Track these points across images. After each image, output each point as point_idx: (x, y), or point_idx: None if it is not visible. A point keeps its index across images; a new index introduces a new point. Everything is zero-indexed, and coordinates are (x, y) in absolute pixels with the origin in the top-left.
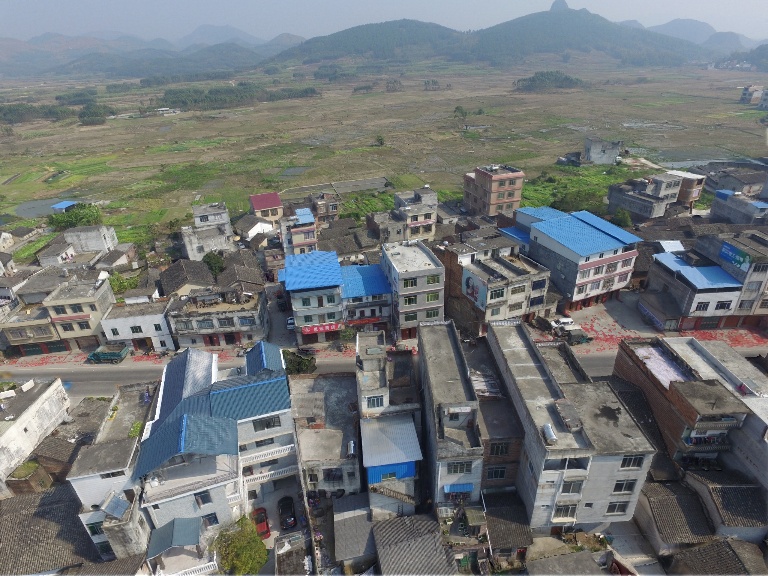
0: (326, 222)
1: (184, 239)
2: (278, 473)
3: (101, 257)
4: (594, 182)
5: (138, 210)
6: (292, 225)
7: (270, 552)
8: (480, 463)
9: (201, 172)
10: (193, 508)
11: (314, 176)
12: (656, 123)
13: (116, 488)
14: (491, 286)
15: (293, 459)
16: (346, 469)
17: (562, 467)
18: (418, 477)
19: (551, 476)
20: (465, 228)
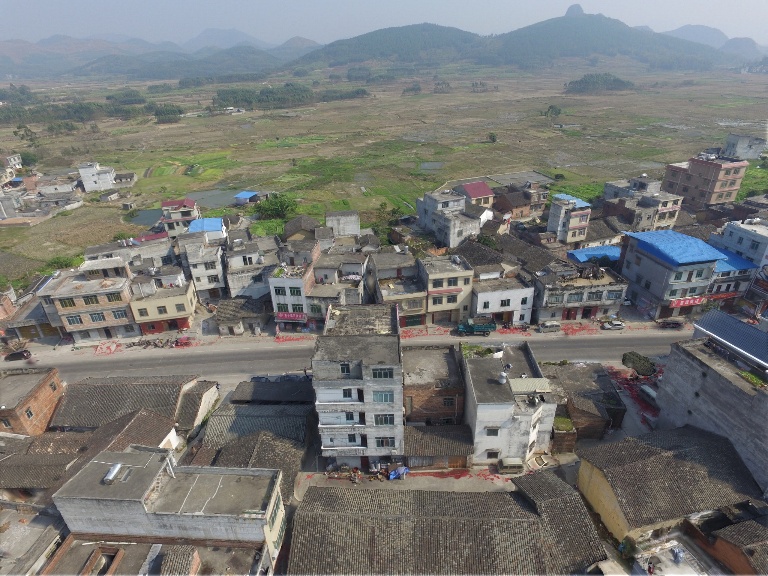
0: (534, 211)
1: (450, 223)
2: None
3: (360, 241)
4: (758, 175)
5: (316, 200)
6: (570, 208)
7: None
8: None
9: (336, 166)
10: None
11: (459, 170)
12: (751, 122)
13: None
14: None
15: None
16: None
17: None
18: None
19: None
20: (728, 213)
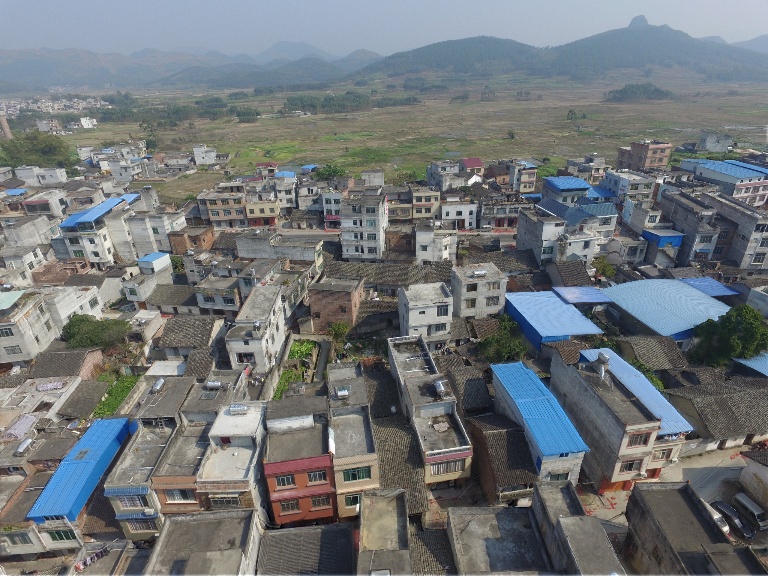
0: None
1: (443, 178)
2: (599, 253)
3: None
4: None
5: None
6: (522, 168)
7: (616, 270)
8: (717, 237)
9: (379, 153)
10: (581, 249)
11: None
12: (756, 126)
13: (557, 233)
14: (683, 191)
15: (605, 249)
16: (640, 247)
17: (762, 231)
18: (680, 248)
19: (757, 235)
20: None
